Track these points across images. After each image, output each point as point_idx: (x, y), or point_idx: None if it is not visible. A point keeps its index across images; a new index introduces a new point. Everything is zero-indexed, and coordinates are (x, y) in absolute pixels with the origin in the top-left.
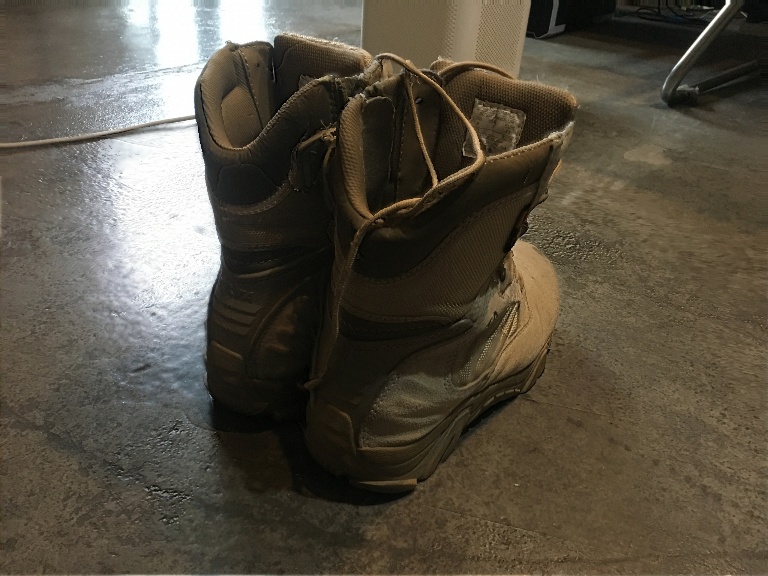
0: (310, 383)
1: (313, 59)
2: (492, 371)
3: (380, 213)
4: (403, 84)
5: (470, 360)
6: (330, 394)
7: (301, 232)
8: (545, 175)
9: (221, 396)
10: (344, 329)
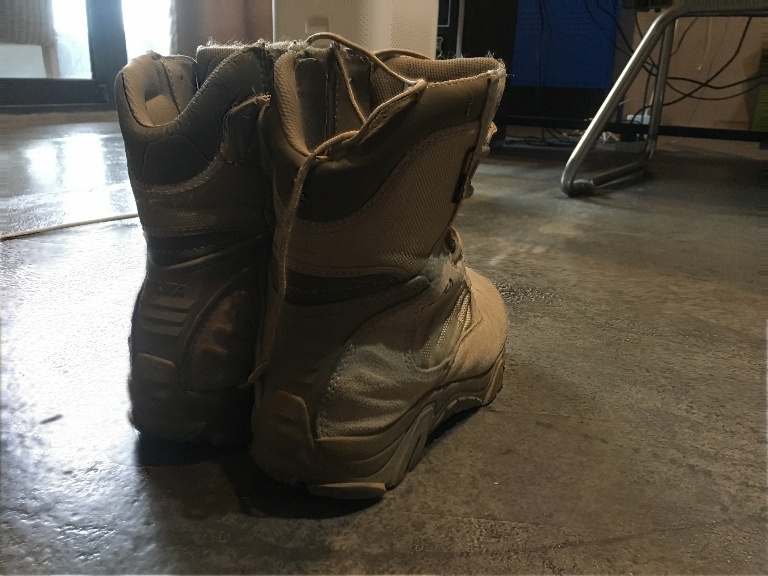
0: (255, 369)
1: None
2: (453, 359)
3: (324, 144)
4: (333, 55)
5: (429, 339)
6: (279, 378)
7: (236, 214)
8: (485, 114)
9: (149, 422)
10: (291, 296)
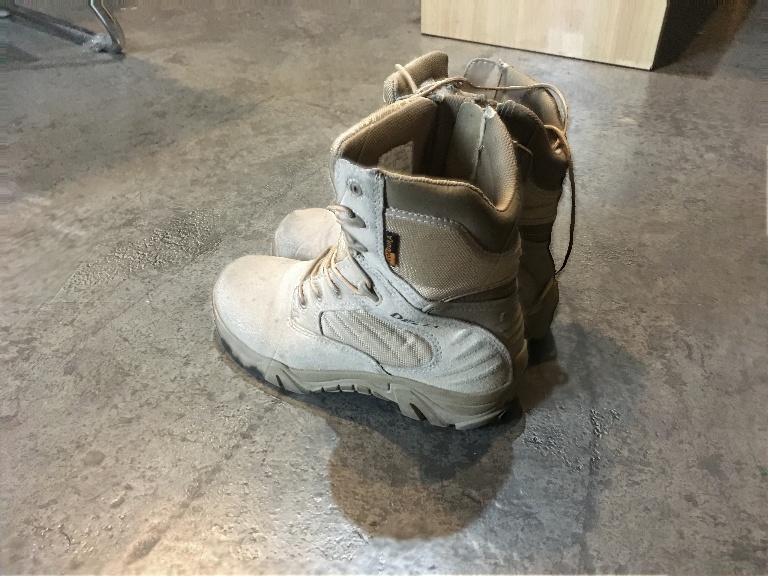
0: None
1: (386, 135)
2: None
3: None
4: None
5: None
6: None
7: None
8: None
9: None
10: None
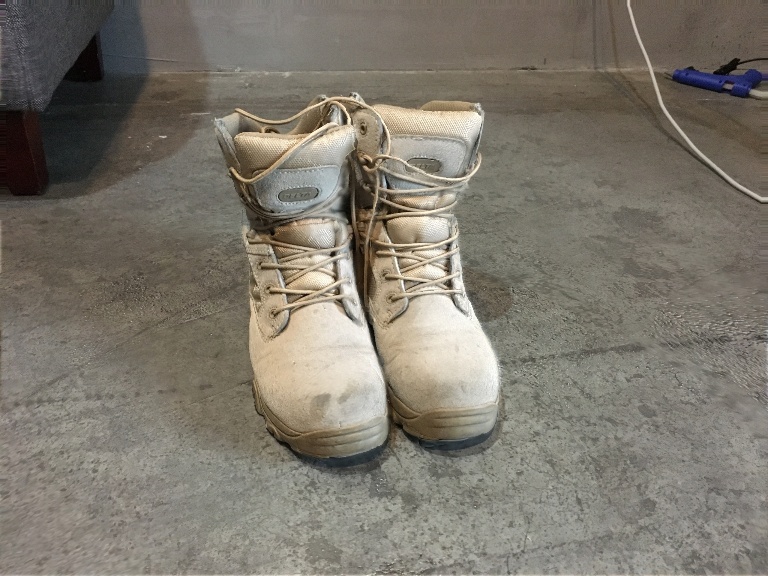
0: None
1: None
2: None
3: None
4: None
5: None
6: None
7: None
8: None
9: None
10: None
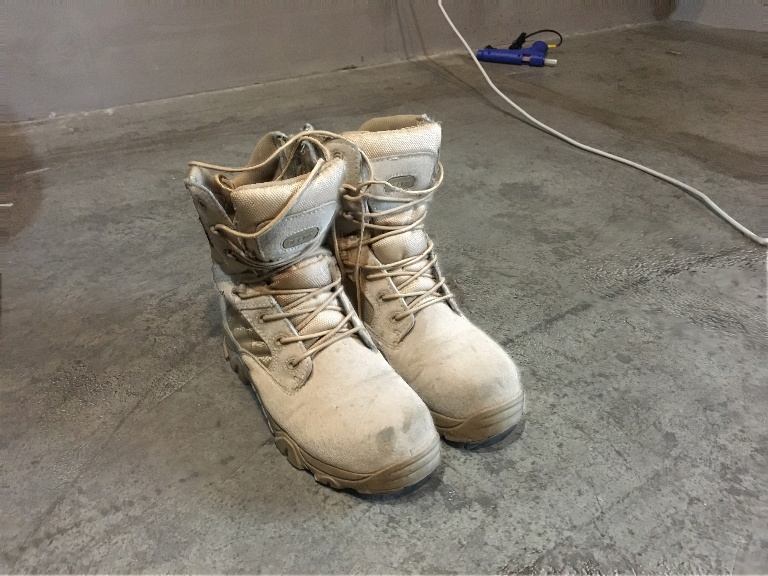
0: None
1: None
2: None
3: None
4: None
5: None
6: None
7: None
8: None
9: None
10: None
